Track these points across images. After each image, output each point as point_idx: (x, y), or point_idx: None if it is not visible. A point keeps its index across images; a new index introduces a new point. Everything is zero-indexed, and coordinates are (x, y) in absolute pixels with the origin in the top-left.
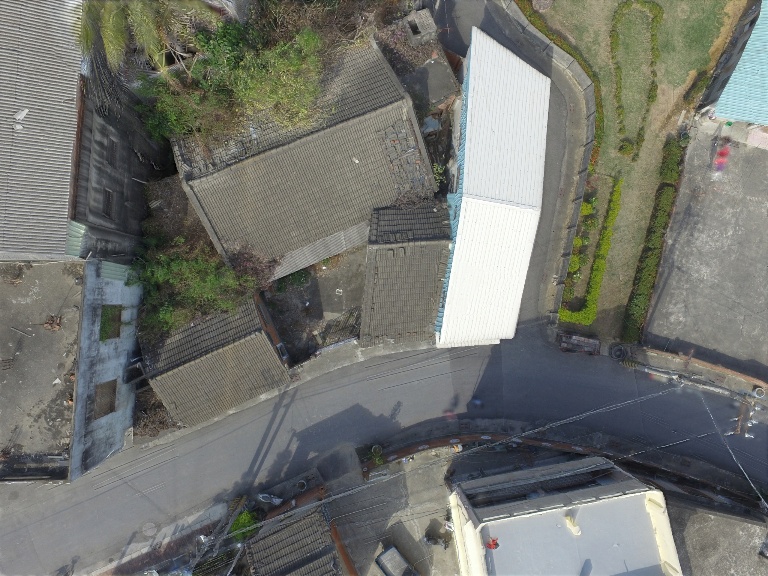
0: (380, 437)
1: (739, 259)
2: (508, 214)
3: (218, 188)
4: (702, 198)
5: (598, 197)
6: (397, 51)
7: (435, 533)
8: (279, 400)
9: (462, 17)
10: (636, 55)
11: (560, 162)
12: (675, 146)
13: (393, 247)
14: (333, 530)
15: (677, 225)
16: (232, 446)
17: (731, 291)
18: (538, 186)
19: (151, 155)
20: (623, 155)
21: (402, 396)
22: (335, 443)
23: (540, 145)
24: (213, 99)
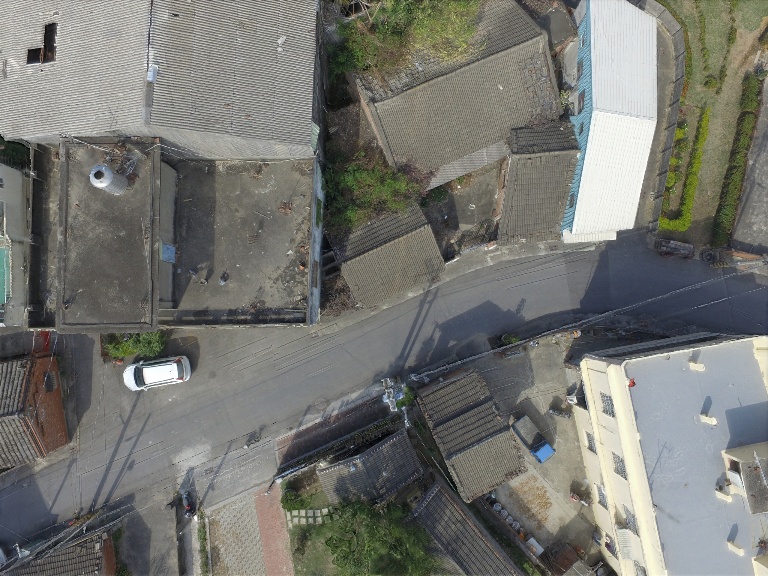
0: (508, 329)
1: None
2: (630, 124)
3: (395, 110)
4: None
5: None
6: (525, 2)
7: (558, 407)
8: (424, 297)
9: None
10: (716, 5)
11: None
12: (754, 80)
13: (532, 157)
14: None
15: (757, 148)
16: (386, 335)
17: None
18: (653, 102)
19: (327, 92)
20: (708, 89)
21: (525, 294)
22: (471, 333)
23: (652, 70)
24: (391, 39)
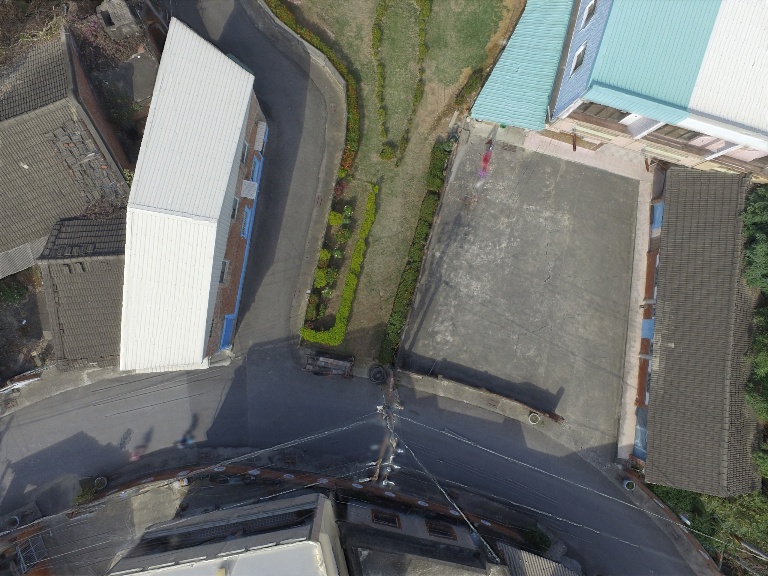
0: (108, 468)
1: (513, 273)
2: (181, 226)
3: None
4: (474, 207)
5: (358, 205)
6: (97, 45)
7: None
8: None
9: (208, 9)
10: (403, 51)
11: (317, 167)
12: (440, 150)
13: (68, 262)
14: (34, 573)
15: (446, 236)
16: None
17: (504, 308)
18: (219, 195)
19: None
20: (384, 160)
21: (133, 423)
22: (56, 475)
23: (229, 149)
24: None
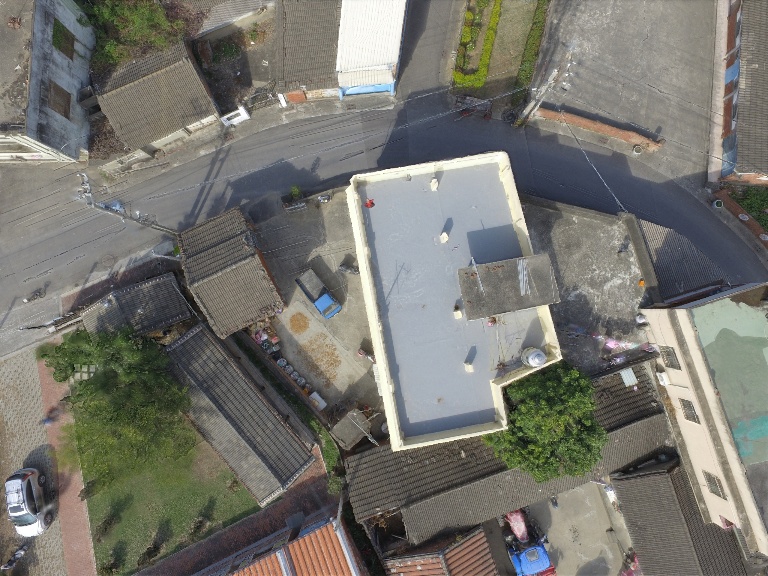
0: (302, 187)
1: (618, 35)
2: None
3: None
4: None
5: None
6: None
7: (349, 265)
8: (216, 155)
9: None
10: None
11: None
12: None
13: None
14: (258, 252)
15: (561, 7)
16: None
17: (611, 62)
18: None
19: None
20: None
21: (321, 153)
22: (264, 192)
23: None
24: None
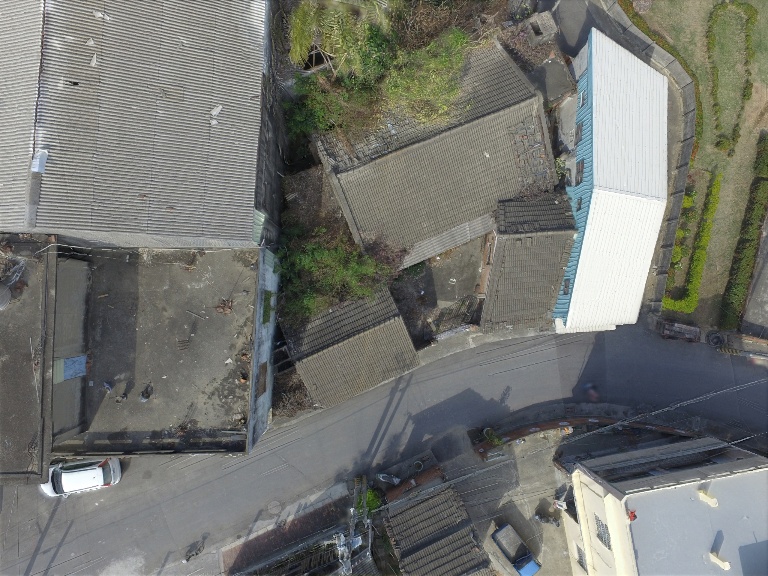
0: (490, 420)
1: None
2: (636, 205)
3: (362, 181)
4: None
5: None
6: (517, 51)
7: (545, 512)
8: (395, 385)
9: (565, 19)
10: (731, 55)
11: None
12: None
13: (521, 237)
14: None
15: None
16: (351, 428)
17: None
18: (663, 179)
19: (284, 150)
20: (720, 150)
21: (511, 381)
22: (448, 426)
23: (662, 140)
24: (358, 97)
